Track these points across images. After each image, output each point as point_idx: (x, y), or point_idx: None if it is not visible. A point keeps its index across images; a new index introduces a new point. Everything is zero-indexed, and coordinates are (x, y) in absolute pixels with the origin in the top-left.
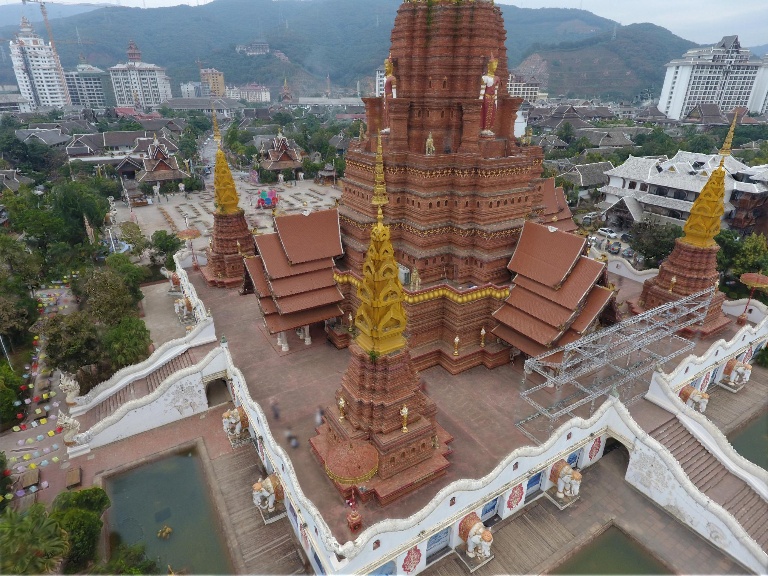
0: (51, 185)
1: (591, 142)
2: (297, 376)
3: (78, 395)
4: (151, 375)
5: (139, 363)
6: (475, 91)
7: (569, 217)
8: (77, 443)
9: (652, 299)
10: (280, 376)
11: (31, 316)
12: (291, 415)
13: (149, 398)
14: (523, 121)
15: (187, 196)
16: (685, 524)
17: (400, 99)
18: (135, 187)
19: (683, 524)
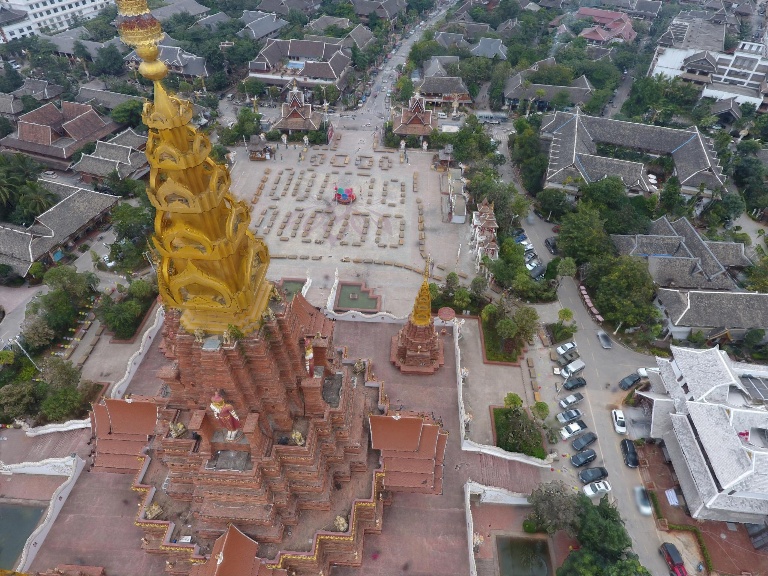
0: (215, 114)
1: None
2: (101, 503)
3: (29, 427)
4: (65, 433)
5: (59, 424)
6: None
7: (429, 459)
8: (4, 469)
9: None
10: (94, 496)
11: (70, 323)
12: (62, 542)
13: (37, 464)
14: None
15: (301, 156)
16: None
17: (164, 377)
18: (258, 142)
19: None
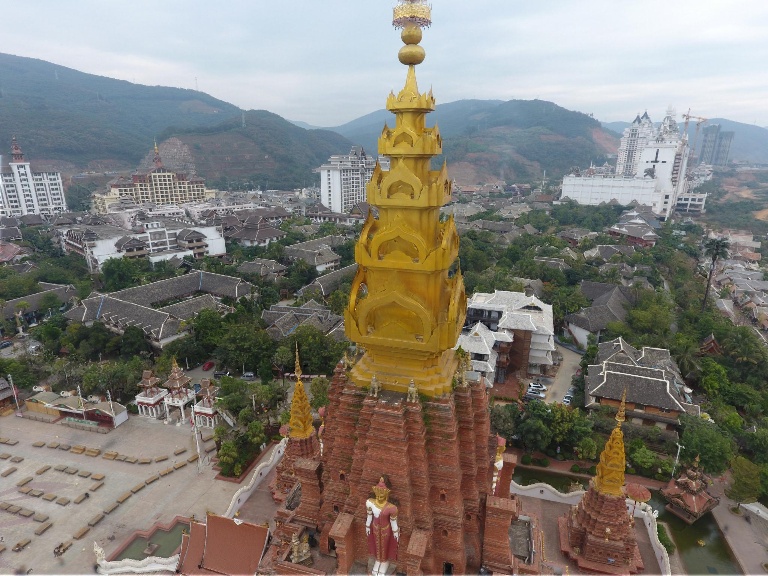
0: None
1: (307, 262)
2: None
3: None
4: None
5: None
6: (487, 480)
7: None
8: None
9: (592, 550)
10: None
11: None
12: None
13: None
14: (219, 236)
15: None
16: None
17: (425, 547)
18: None
19: None
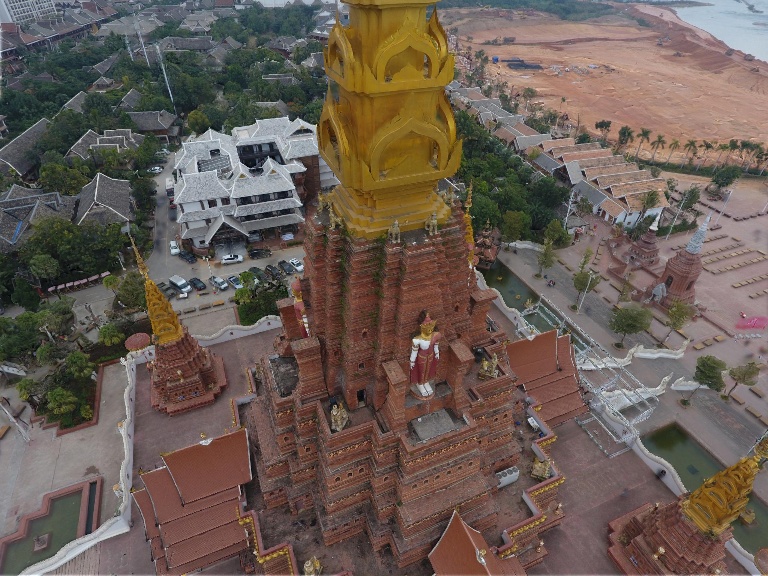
0: None
1: None
2: None
3: None
4: None
5: None
6: None
7: None
8: None
9: None
10: None
11: None
12: None
13: None
14: None
15: None
16: (628, 407)
17: (469, 351)
18: None
19: (628, 408)
